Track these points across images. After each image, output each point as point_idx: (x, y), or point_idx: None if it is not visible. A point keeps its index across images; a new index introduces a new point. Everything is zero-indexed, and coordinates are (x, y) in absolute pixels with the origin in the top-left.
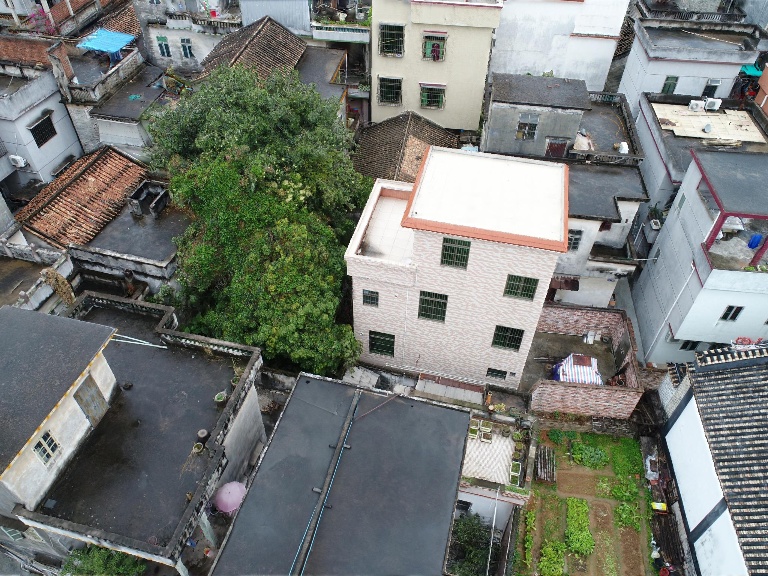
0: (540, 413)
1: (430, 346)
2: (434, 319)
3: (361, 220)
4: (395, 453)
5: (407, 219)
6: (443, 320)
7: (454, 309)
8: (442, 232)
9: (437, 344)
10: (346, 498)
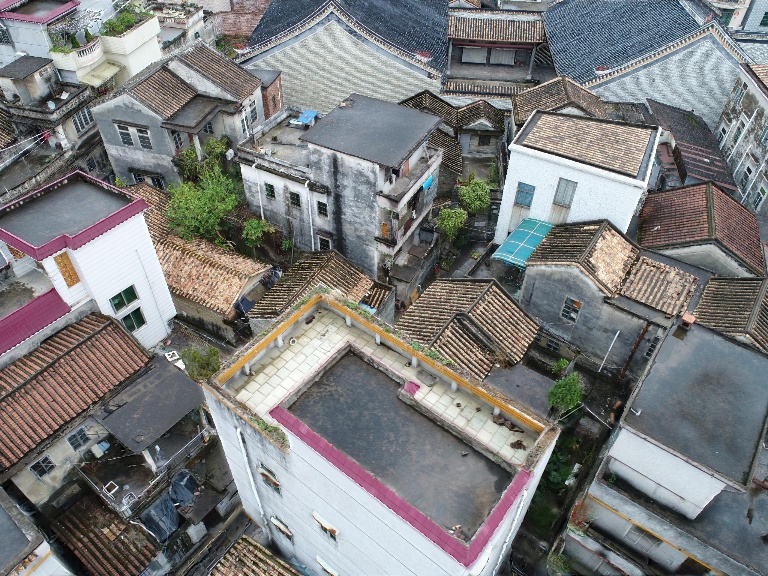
0: (229, 35)
1: None
2: None
3: None
4: None
5: None
6: None
7: None
8: None
9: None
10: None
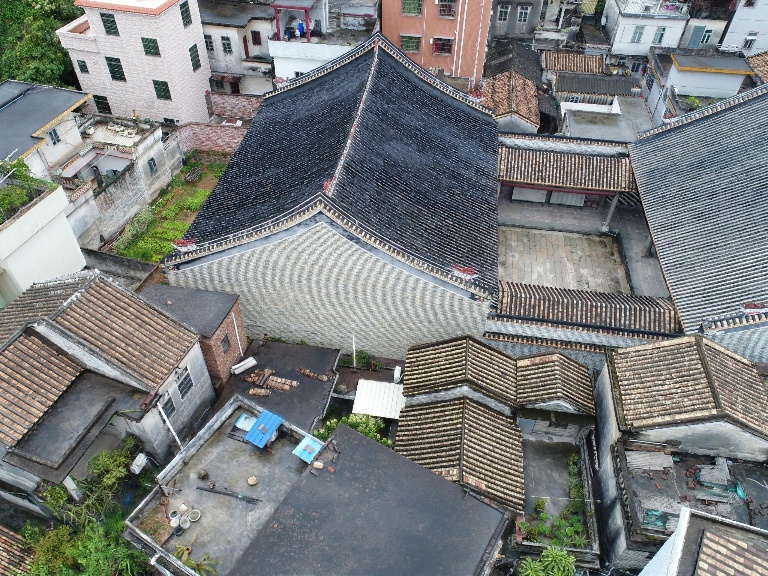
0: (201, 151)
1: (128, 103)
2: (122, 80)
3: (78, 19)
4: (38, 105)
5: (77, 0)
6: (126, 80)
7: (127, 70)
8: (95, 7)
9: (130, 101)
10: (1, 116)
